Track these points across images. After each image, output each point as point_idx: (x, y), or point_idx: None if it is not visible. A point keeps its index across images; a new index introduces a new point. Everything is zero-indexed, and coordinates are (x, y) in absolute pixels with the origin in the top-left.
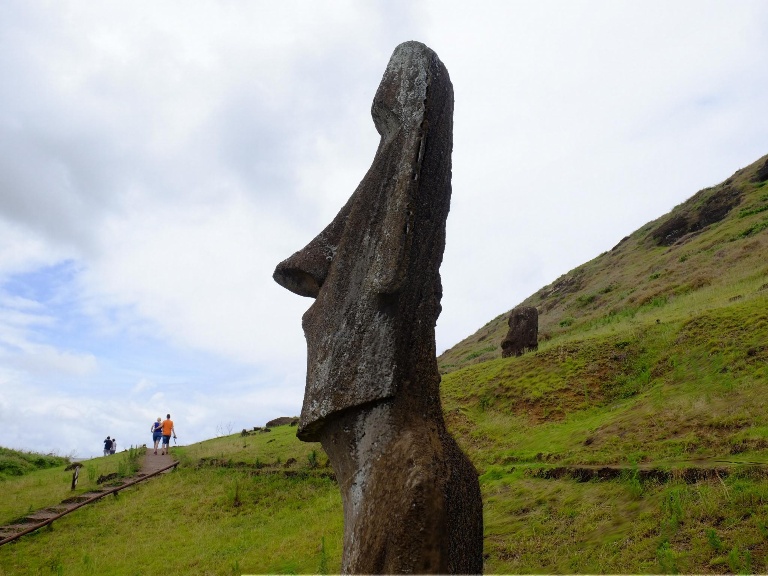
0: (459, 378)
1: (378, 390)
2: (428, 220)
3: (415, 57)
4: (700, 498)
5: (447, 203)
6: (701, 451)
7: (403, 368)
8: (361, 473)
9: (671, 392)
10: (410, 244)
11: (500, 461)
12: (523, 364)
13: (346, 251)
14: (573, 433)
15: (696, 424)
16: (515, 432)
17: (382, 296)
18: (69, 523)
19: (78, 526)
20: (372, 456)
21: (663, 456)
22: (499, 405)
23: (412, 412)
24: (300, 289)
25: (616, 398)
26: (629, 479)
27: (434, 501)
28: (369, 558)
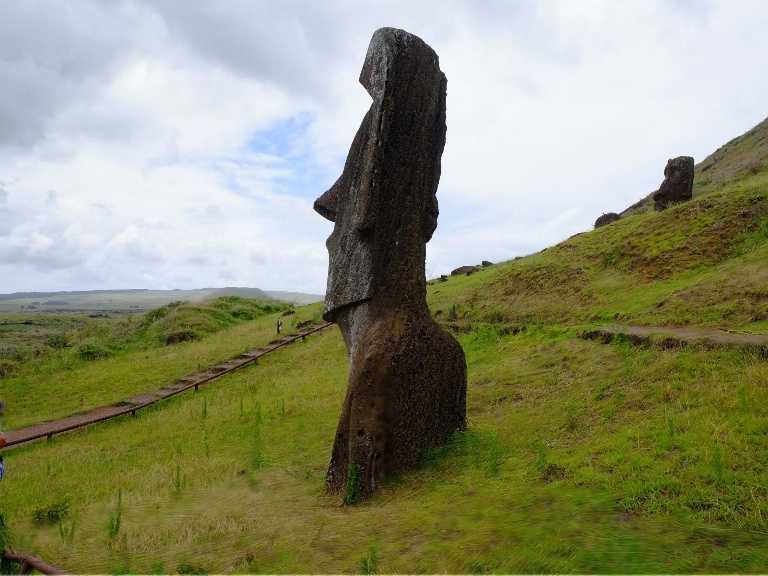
0: (600, 235)
1: (359, 294)
2: (404, 166)
3: (380, 45)
4: (653, 363)
5: (441, 139)
6: (733, 317)
7: (380, 278)
8: (352, 347)
9: (762, 255)
10: (377, 193)
11: (588, 319)
12: (658, 221)
13: (340, 198)
14: (660, 294)
15: (744, 291)
16: (619, 291)
17: (359, 231)
18: (269, 360)
19: (275, 362)
20: (358, 337)
21: (703, 321)
22: (620, 263)
23: (387, 307)
24: (330, 218)
25: (728, 257)
26: (632, 344)
27: (380, 367)
28: (347, 399)
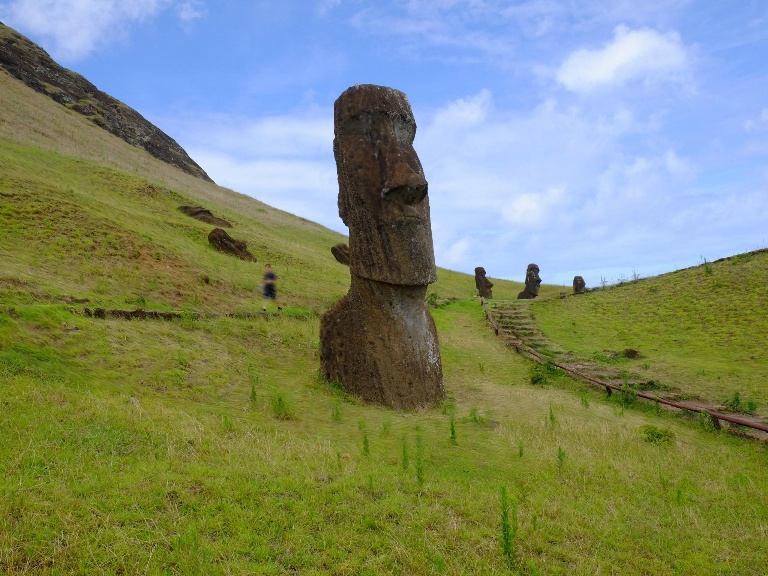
0: None
1: None
2: None
3: None
4: None
5: None
6: (43, 301)
7: None
8: None
9: None
10: None
11: None
12: None
13: None
14: None
15: None
16: None
17: None
18: None
19: None
20: None
21: None
22: None
23: None
24: None
25: None
26: None
27: None
28: None
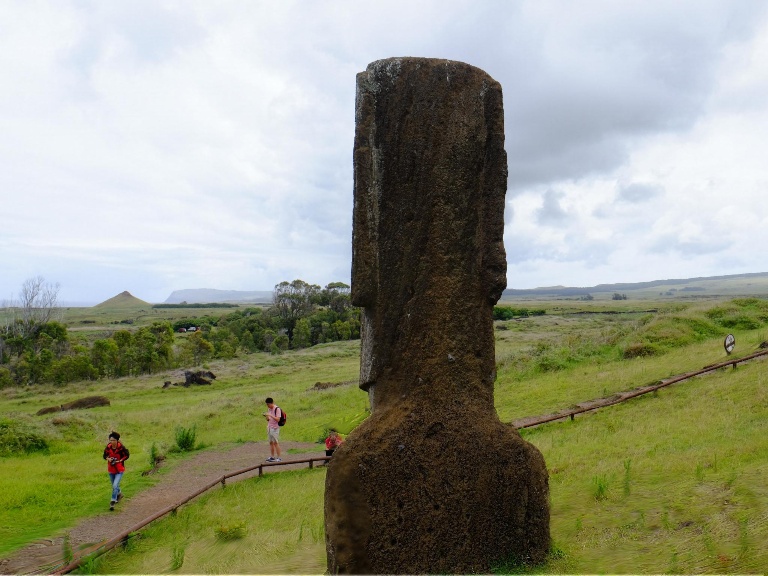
0: None
1: (365, 376)
2: (412, 221)
3: None
4: None
5: (497, 169)
6: None
7: (386, 358)
8: None
9: None
10: (360, 262)
11: None
12: None
13: None
14: None
15: None
16: None
17: None
18: (672, 392)
19: (676, 396)
20: None
21: None
22: None
23: (393, 393)
24: None
25: None
26: None
27: (340, 468)
28: None
